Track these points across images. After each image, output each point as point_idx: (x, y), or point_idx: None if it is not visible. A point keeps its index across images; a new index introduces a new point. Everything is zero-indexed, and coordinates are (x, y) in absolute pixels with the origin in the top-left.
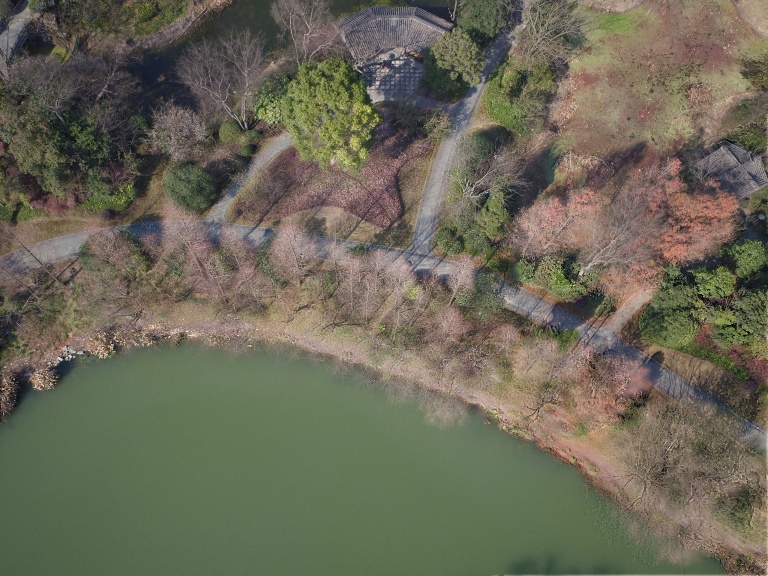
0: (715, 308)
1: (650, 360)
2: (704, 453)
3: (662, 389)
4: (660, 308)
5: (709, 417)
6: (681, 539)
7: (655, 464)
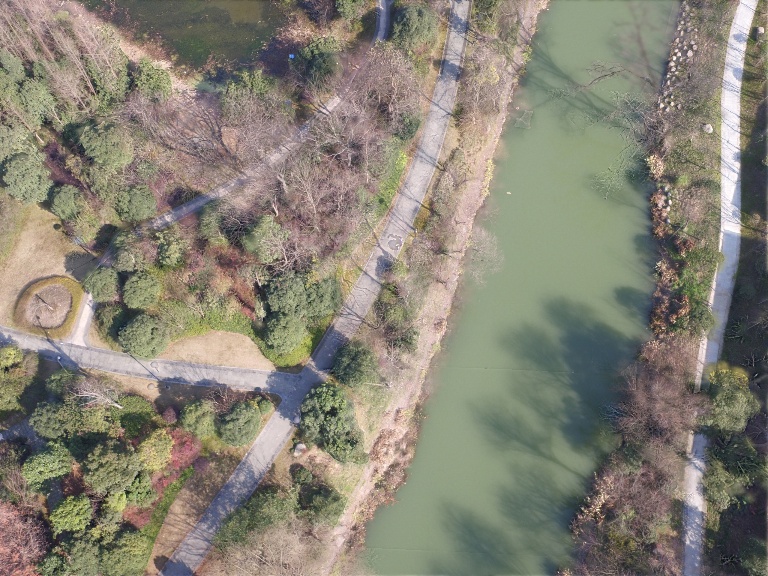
0: (103, 516)
1: (163, 573)
2: (269, 522)
3: (197, 563)
4: (98, 573)
5: (232, 510)
6: (355, 546)
7: (278, 575)
